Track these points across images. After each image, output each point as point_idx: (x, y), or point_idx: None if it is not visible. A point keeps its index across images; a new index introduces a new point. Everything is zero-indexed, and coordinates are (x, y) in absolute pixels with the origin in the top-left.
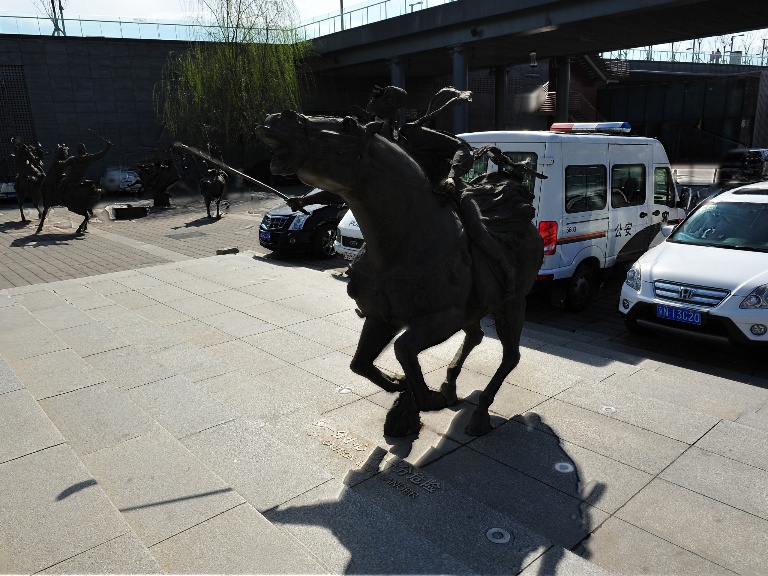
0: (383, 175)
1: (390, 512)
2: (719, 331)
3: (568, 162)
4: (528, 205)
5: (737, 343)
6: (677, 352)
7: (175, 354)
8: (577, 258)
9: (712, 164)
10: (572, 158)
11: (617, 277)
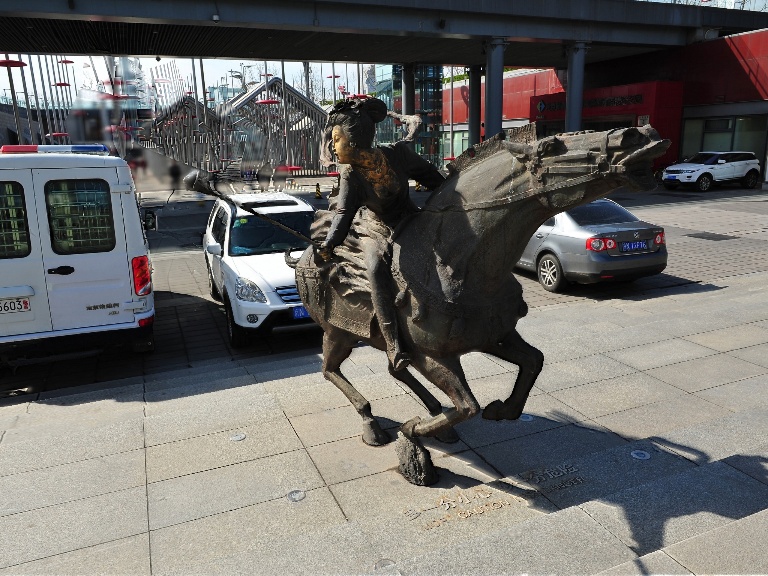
0: None
1: None
2: None
3: None
4: None
5: None
6: (291, 347)
7: None
8: None
9: (171, 186)
10: None
11: None
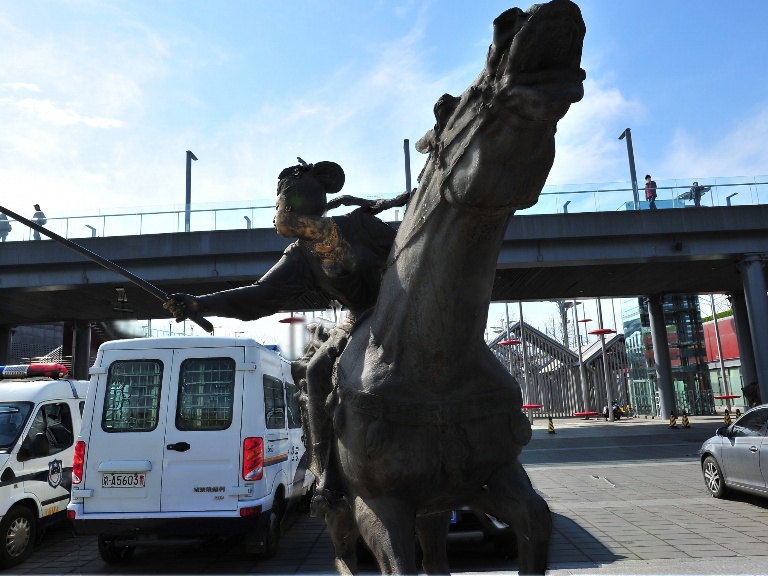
0: None
1: None
2: (472, 526)
3: (263, 371)
4: None
5: (489, 535)
6: None
7: None
8: (274, 485)
9: None
10: (264, 367)
11: (287, 512)
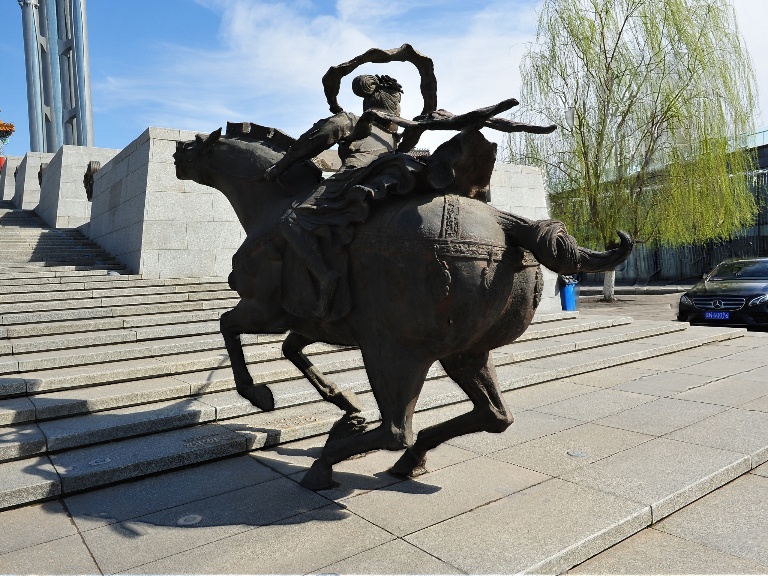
0: (216, 172)
1: (175, 435)
2: None
3: None
4: (357, 186)
5: None
6: None
7: (517, 370)
8: None
9: None
10: None
11: None
